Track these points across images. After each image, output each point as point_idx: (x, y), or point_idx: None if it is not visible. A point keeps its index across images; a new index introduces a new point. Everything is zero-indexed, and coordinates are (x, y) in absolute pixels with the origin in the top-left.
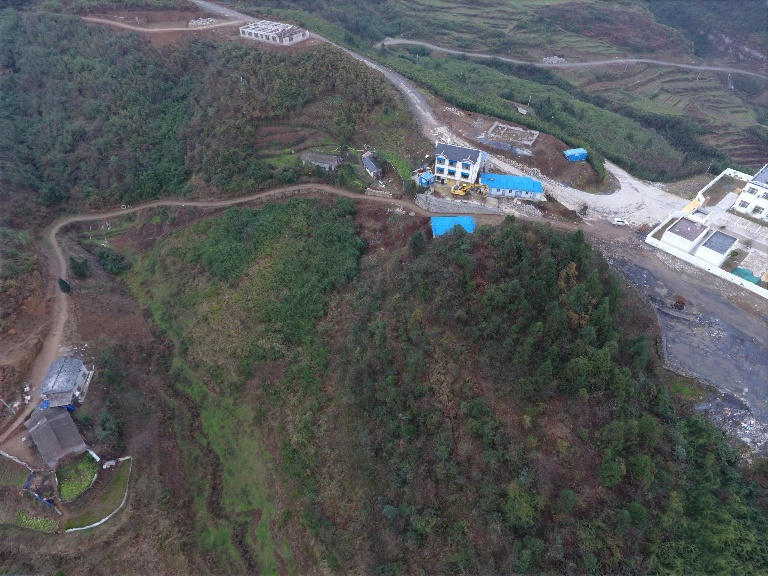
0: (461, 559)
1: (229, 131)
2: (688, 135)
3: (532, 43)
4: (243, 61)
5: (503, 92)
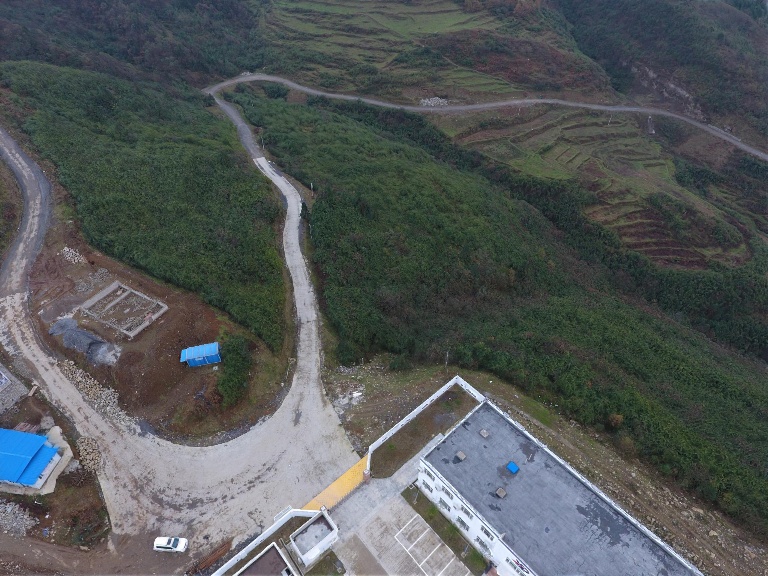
0: None
1: None
2: (571, 207)
3: (408, 82)
4: None
5: (295, 170)
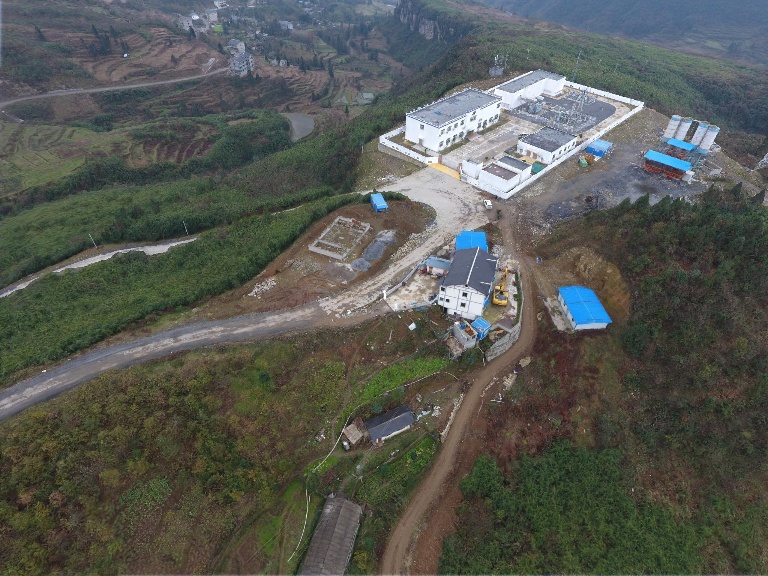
0: None
1: None
2: (122, 170)
3: None
4: None
5: (20, 268)
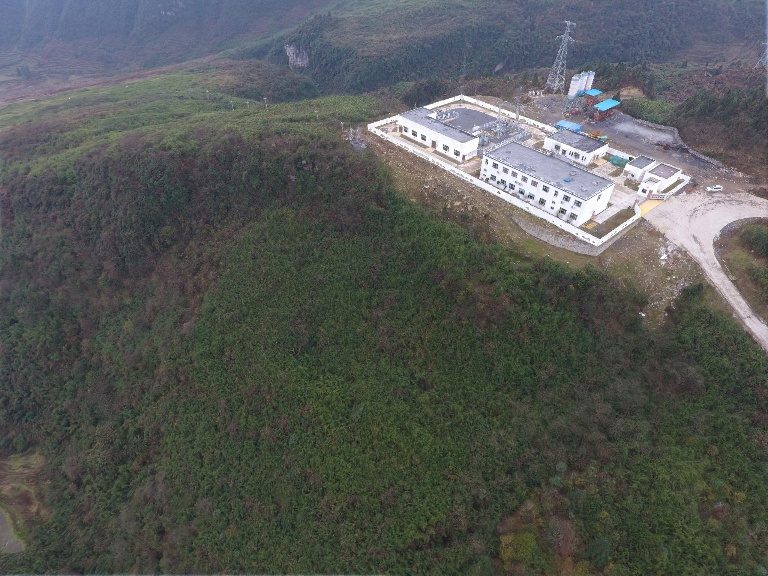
0: None
1: None
2: None
3: None
4: None
5: None
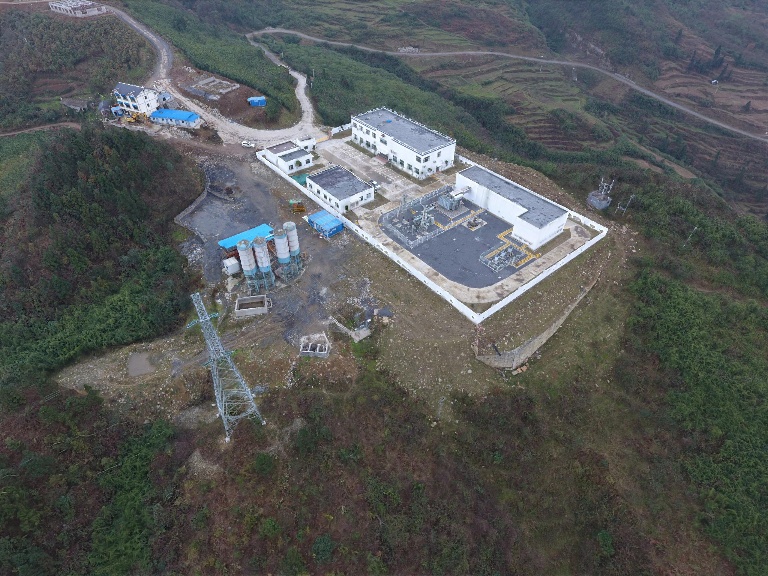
0: None
1: (9, 80)
2: (496, 114)
3: (389, 34)
4: (37, 28)
5: None
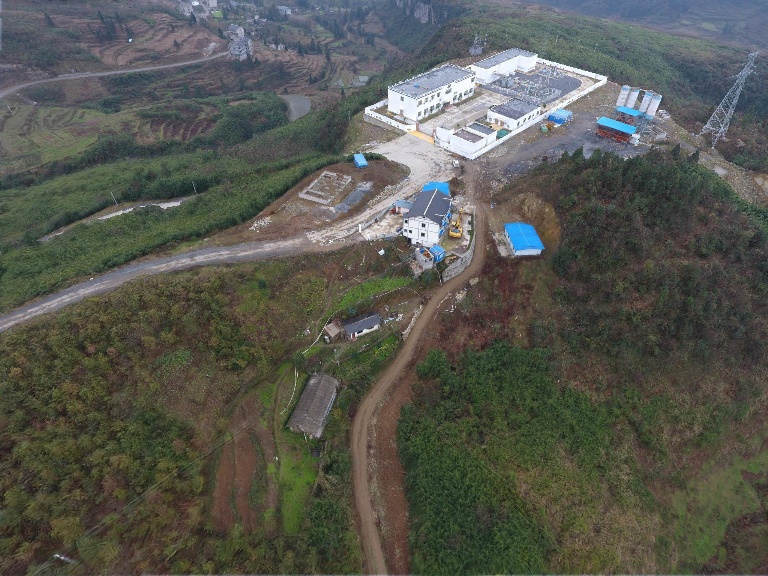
0: (762, 282)
1: None
2: (132, 147)
3: None
4: None
5: (53, 221)
